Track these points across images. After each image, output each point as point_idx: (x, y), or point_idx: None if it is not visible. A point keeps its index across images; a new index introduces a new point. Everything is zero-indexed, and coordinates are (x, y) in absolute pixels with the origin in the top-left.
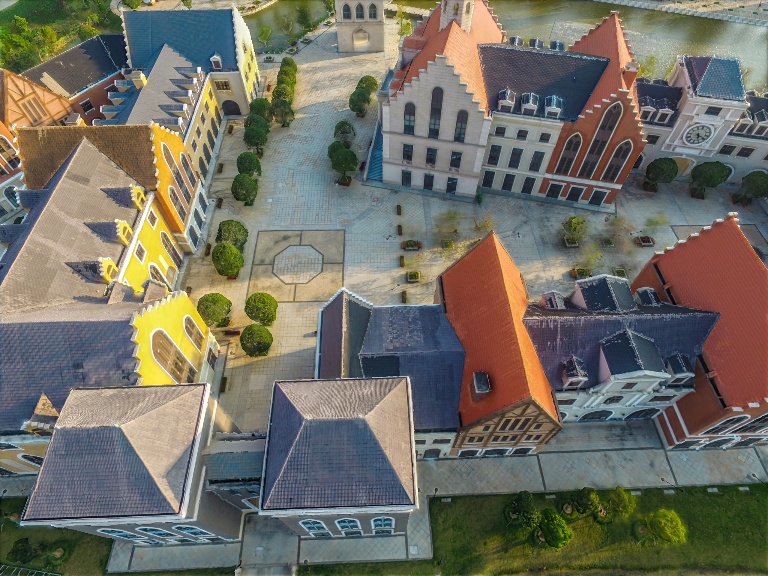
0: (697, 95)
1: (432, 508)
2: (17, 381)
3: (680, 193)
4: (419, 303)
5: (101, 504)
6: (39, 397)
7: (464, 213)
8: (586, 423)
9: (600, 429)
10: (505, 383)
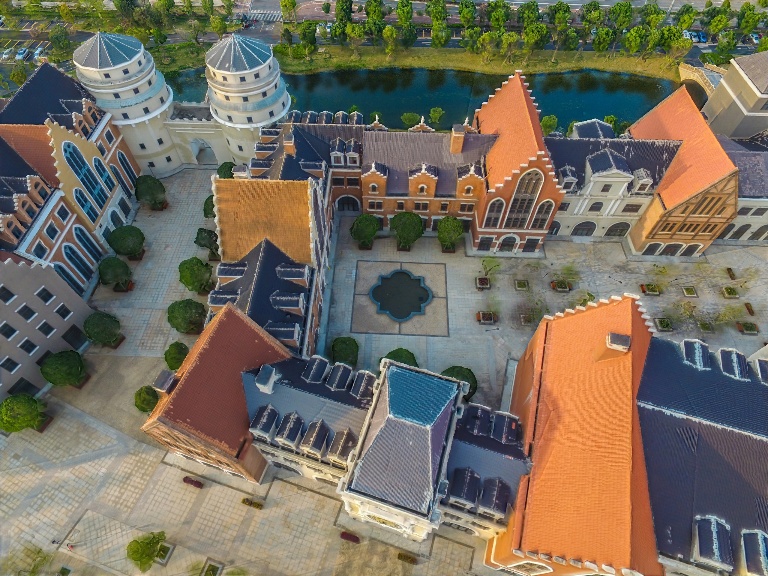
0: (459, 382)
1: None
2: None
3: None
4: (714, 269)
5: None
6: None
7: None
8: None
9: None
10: None
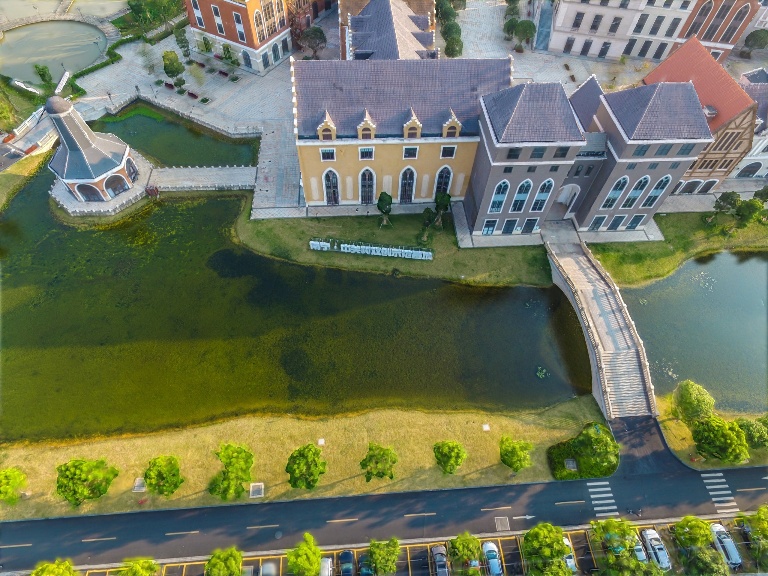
0: None
1: (655, 218)
2: (436, 99)
3: (767, 60)
4: None
5: (543, 133)
6: (448, 110)
7: (615, 70)
8: (740, 179)
9: (750, 182)
10: (728, 107)
